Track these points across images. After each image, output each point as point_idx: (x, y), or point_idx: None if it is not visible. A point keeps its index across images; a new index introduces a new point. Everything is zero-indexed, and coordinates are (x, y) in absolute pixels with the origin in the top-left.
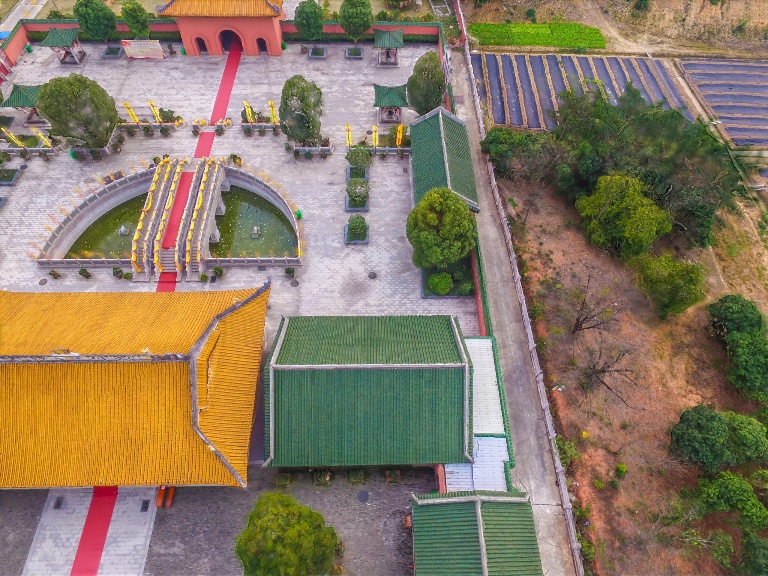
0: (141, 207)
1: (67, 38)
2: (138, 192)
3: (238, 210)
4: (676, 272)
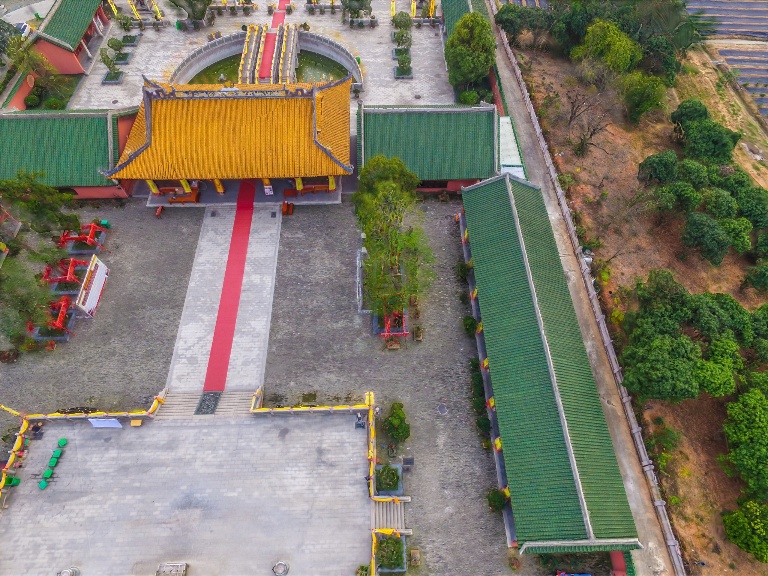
0: (232, 65)
1: None
2: (230, 53)
3: (308, 66)
4: (644, 82)
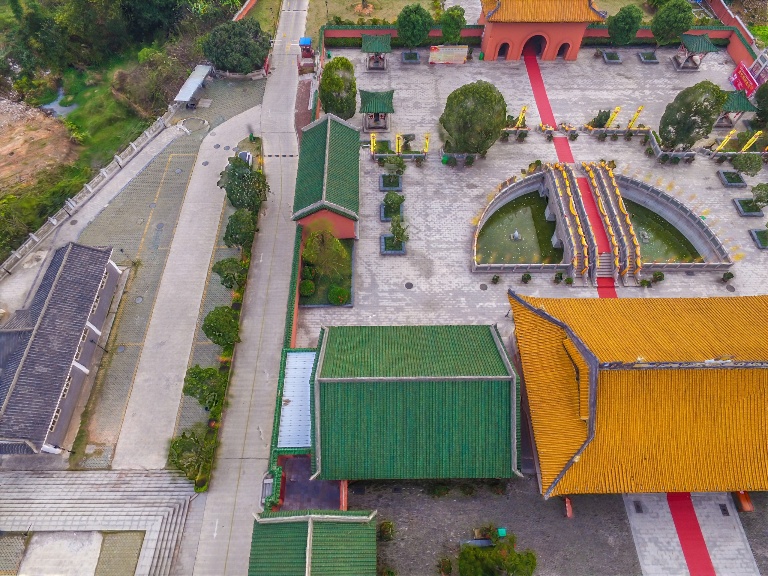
0: (517, 212)
1: (386, 44)
2: (513, 197)
3: None
4: None
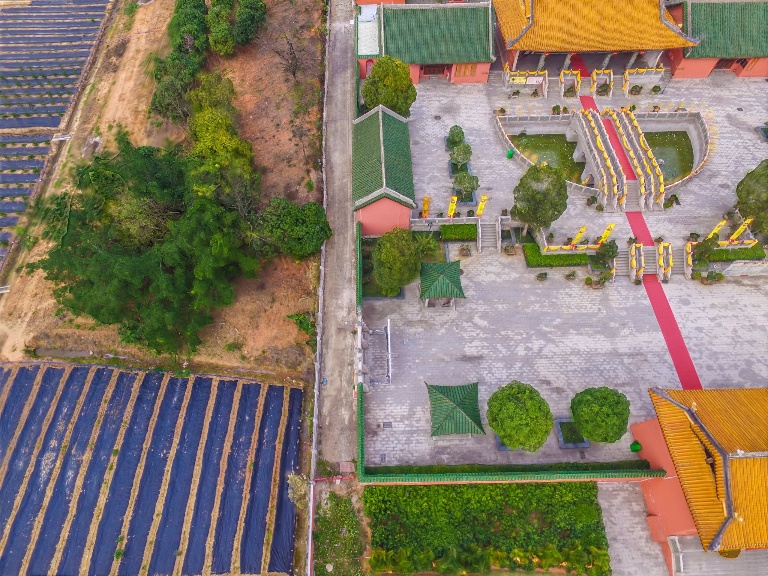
0: None
1: None
2: None
3: None
4: None
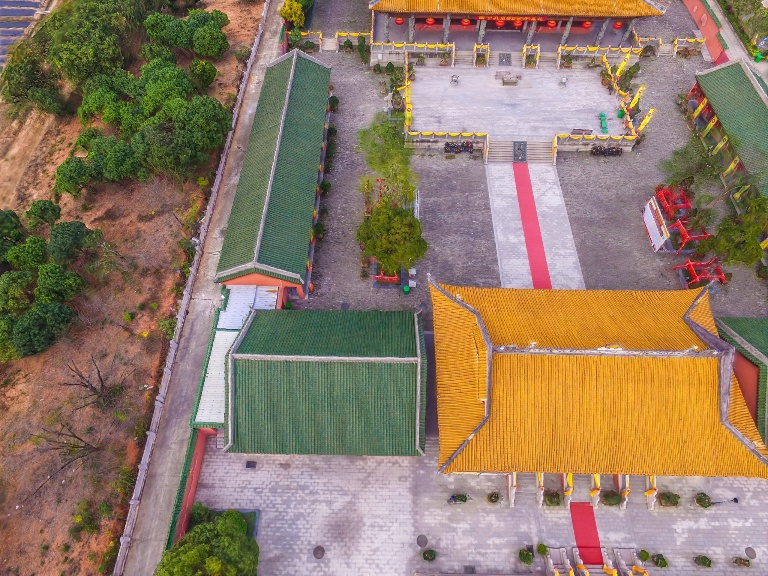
0: None
1: None
2: None
3: None
4: None
